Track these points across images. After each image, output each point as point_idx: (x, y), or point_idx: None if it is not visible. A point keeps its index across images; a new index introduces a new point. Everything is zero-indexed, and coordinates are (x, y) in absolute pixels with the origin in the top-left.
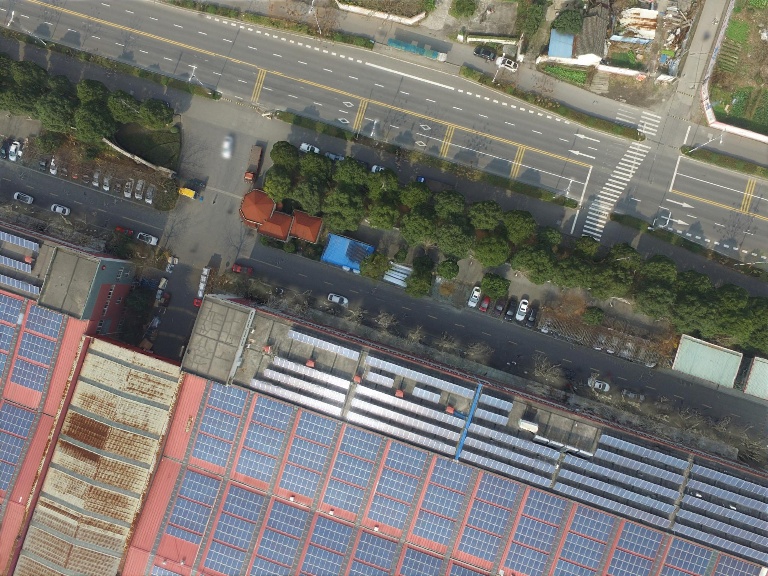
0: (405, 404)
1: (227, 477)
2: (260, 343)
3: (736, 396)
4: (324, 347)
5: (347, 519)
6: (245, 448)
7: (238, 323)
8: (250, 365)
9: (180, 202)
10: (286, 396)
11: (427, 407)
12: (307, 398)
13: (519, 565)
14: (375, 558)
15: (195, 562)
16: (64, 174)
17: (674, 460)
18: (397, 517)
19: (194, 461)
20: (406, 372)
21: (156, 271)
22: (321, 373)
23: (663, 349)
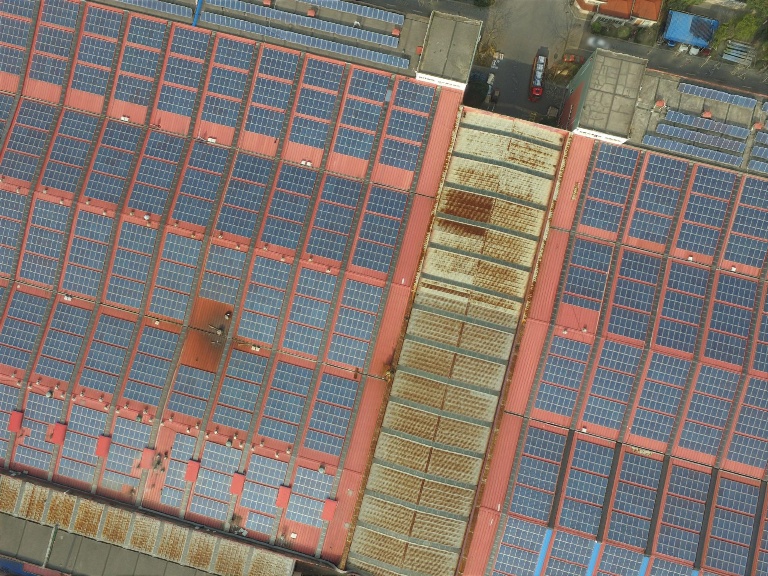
0: None
1: (620, 242)
2: (647, 101)
3: None
4: (717, 98)
5: (750, 274)
6: (638, 210)
7: (634, 75)
8: (638, 124)
9: None
10: (682, 151)
11: None
12: (706, 150)
13: None
14: None
15: (597, 329)
16: None
17: None
18: None
19: (582, 229)
20: None
21: (480, 69)
22: (718, 124)
23: None
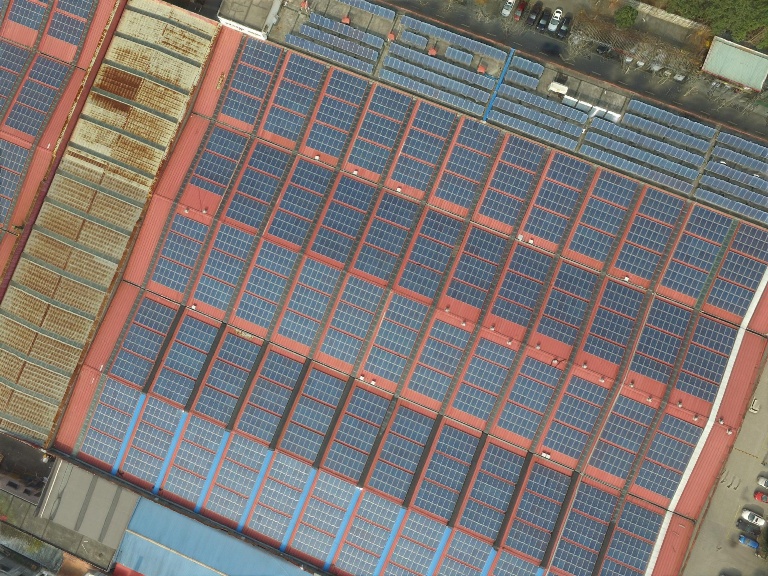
0: (437, 64)
1: (254, 134)
2: (297, 3)
3: (762, 114)
4: (360, 7)
5: (370, 180)
6: (274, 106)
7: None
8: (286, 24)
9: None
10: (319, 53)
11: (458, 68)
12: (340, 54)
13: (538, 229)
14: (396, 217)
15: (217, 212)
16: None
17: (701, 127)
18: (420, 178)
19: (223, 119)
20: (440, 33)
21: None
22: (356, 30)
23: (693, 57)
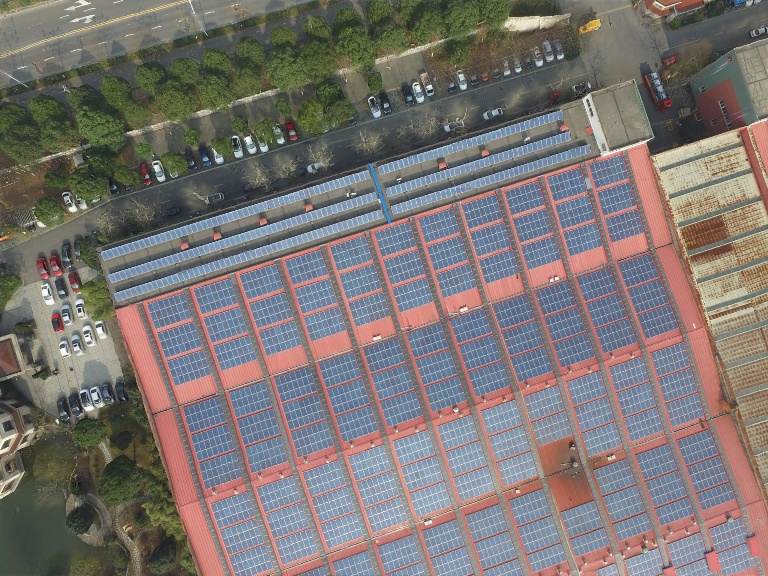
0: None
1: None
2: None
3: None
4: None
5: None
6: None
7: None
8: None
9: (583, 42)
10: None
11: None
12: None
13: None
14: None
15: None
16: (474, 83)
17: None
18: None
19: None
20: None
21: None
22: None
23: None
